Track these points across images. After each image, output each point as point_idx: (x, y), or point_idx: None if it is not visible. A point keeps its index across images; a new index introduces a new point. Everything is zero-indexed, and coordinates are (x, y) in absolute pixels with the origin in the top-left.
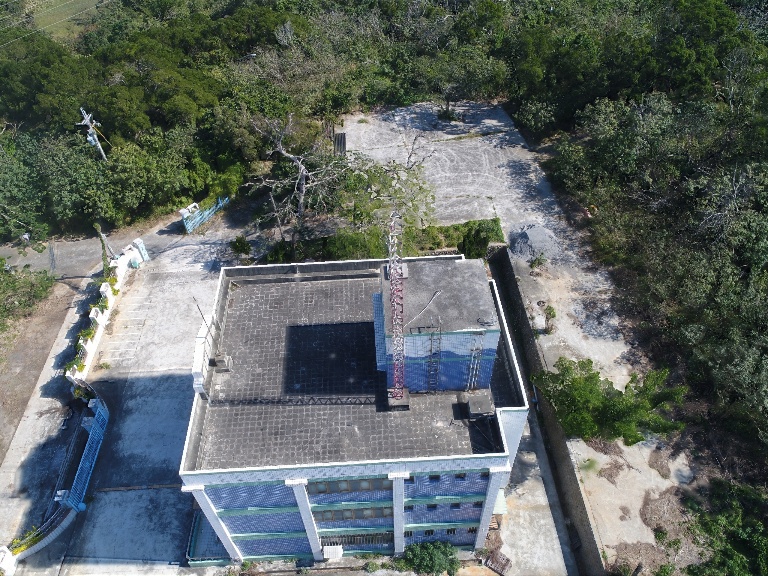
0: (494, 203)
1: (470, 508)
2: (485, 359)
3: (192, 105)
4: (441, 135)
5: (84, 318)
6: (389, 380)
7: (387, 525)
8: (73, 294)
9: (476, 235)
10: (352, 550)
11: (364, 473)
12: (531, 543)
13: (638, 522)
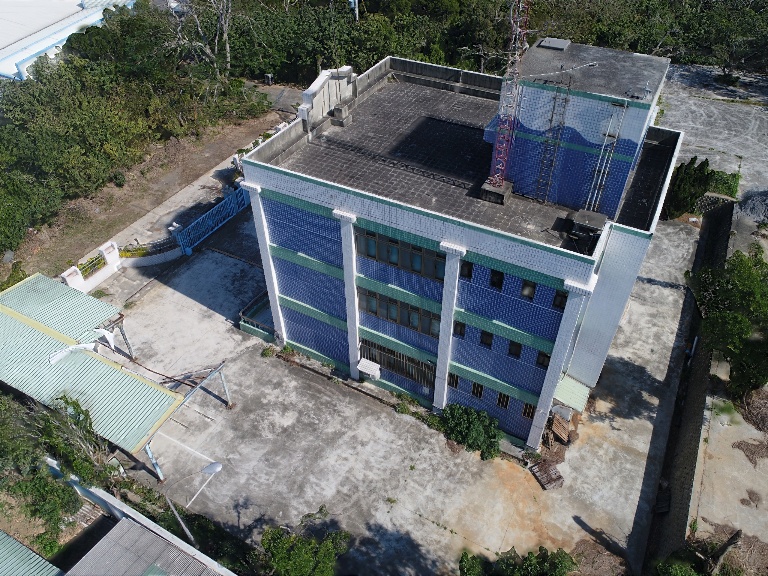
0: (742, 162)
1: (532, 364)
2: (619, 160)
3: (454, 4)
4: (709, 94)
5: None
6: (494, 162)
7: (432, 353)
8: (279, 122)
9: (699, 169)
10: (390, 382)
11: (416, 230)
12: (601, 478)
13: (767, 517)
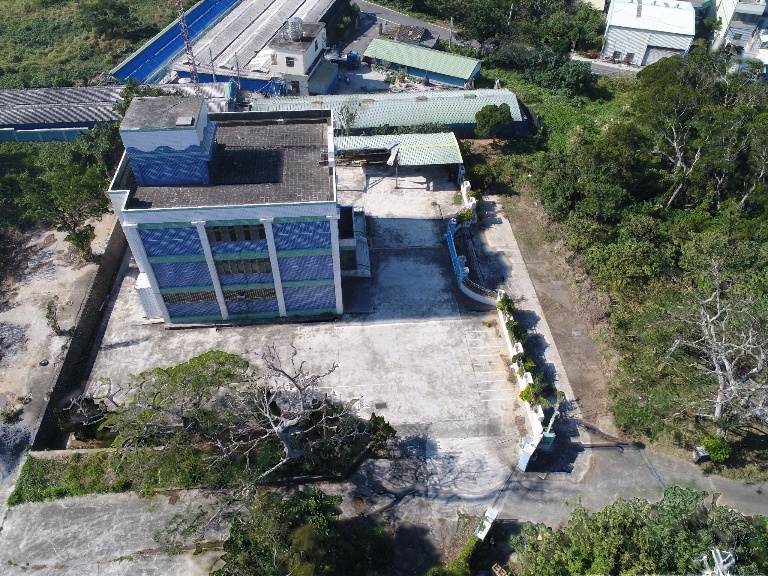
0: None
1: None
2: None
3: None
4: None
5: (549, 386)
6: None
7: None
8: (586, 419)
9: None
10: None
11: None
12: None
13: None
